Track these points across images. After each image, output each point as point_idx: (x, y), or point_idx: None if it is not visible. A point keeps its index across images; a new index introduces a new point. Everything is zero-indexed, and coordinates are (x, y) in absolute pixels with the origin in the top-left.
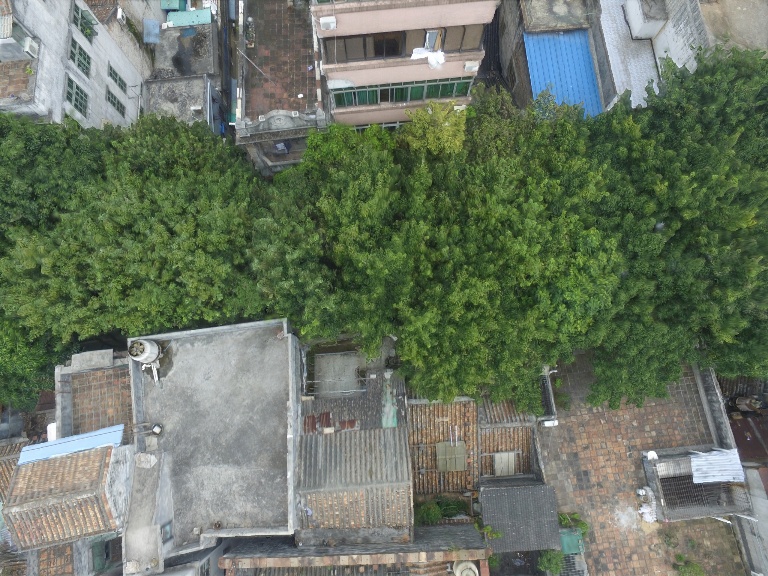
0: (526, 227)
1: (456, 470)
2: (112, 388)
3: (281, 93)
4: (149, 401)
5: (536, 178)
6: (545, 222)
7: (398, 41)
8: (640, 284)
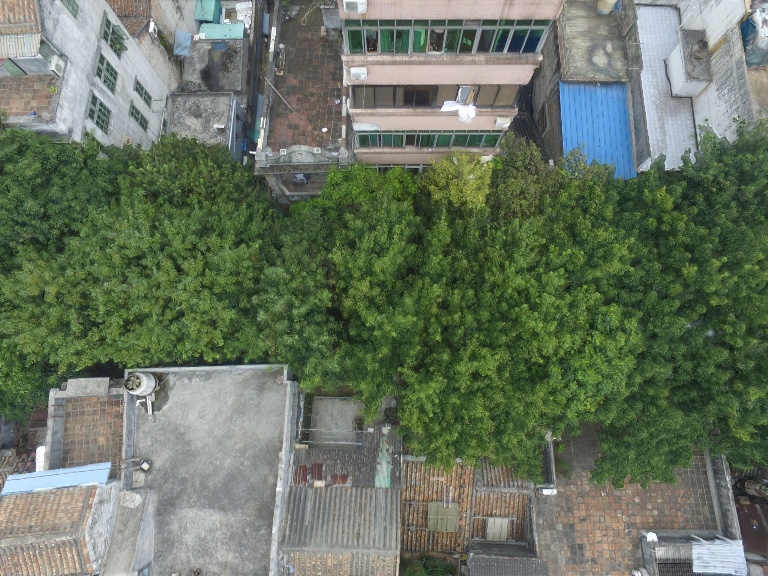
0: (544, 302)
1: (447, 531)
2: (105, 416)
3: (305, 125)
4: (141, 434)
5: (559, 242)
6: (564, 295)
7: (429, 92)
8: (657, 368)
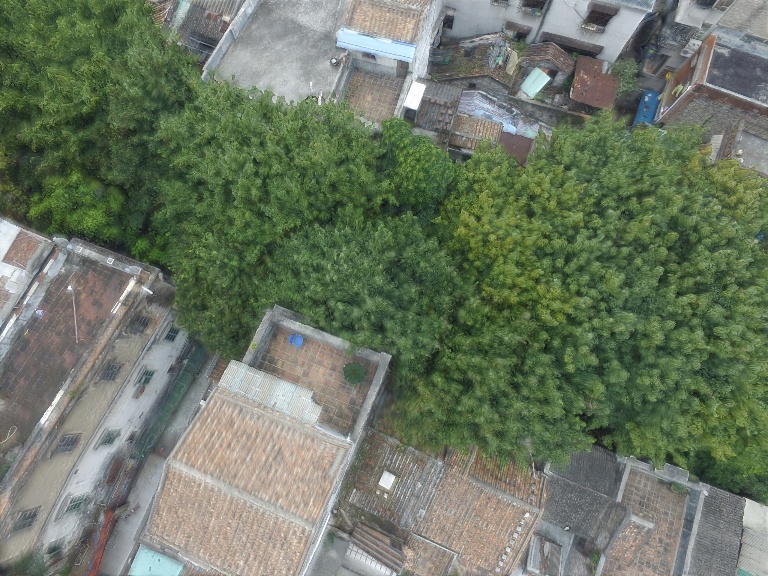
0: None
1: None
2: None
3: (85, 301)
4: None
5: None
6: None
7: None
8: None
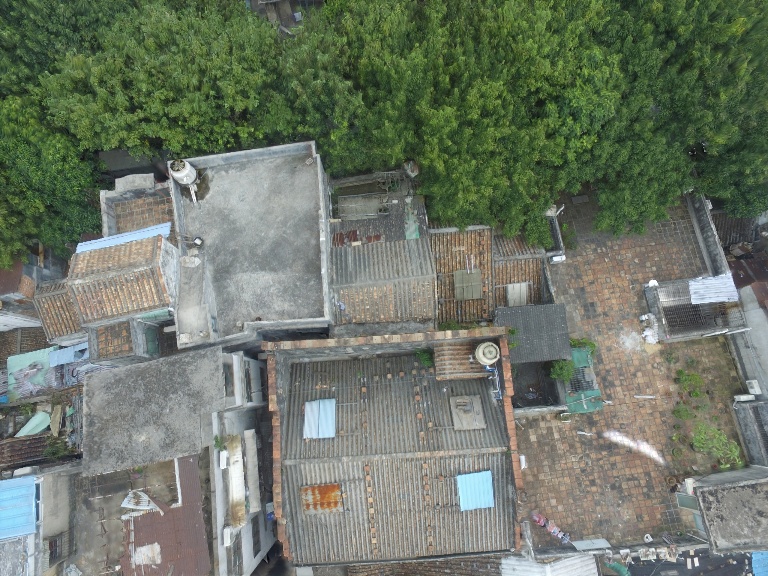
0: (536, 33)
1: (472, 298)
2: (153, 213)
3: None
4: (189, 220)
5: None
6: None
7: None
8: None
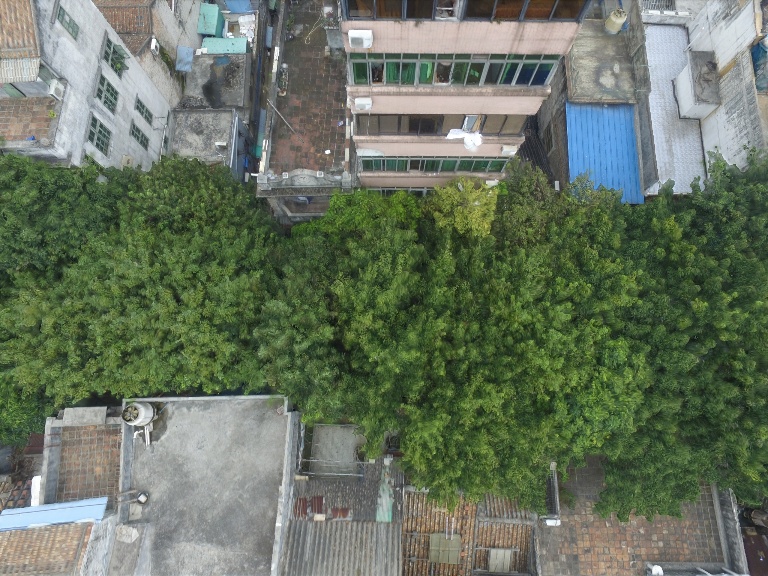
0: (550, 338)
1: (448, 563)
2: (102, 445)
3: (308, 147)
4: (138, 465)
5: (565, 272)
6: (571, 330)
7: (435, 120)
8: (665, 403)
